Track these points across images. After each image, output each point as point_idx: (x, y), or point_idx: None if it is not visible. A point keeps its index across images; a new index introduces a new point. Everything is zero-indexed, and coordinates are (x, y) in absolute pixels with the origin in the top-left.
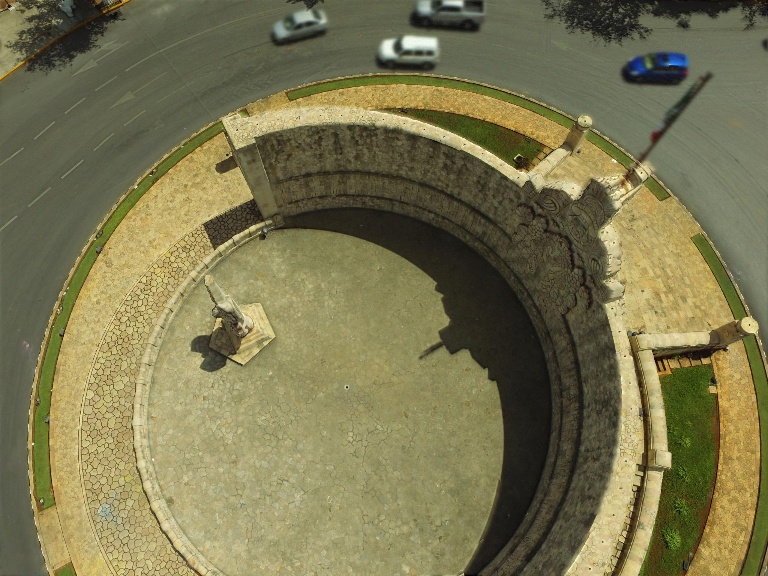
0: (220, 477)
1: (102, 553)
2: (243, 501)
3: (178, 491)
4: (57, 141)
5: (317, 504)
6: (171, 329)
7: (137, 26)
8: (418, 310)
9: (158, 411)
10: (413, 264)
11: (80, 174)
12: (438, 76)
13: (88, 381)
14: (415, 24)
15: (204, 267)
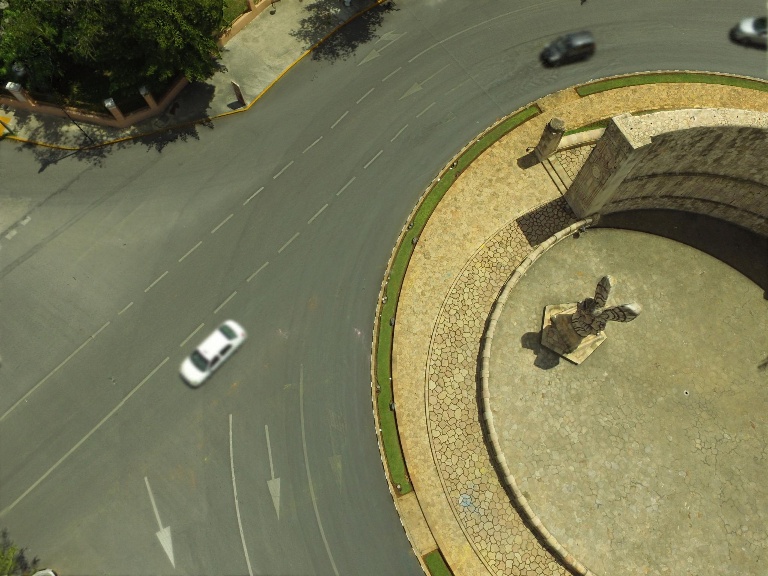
0: (572, 476)
1: (470, 543)
2: (599, 501)
3: (533, 487)
4: (354, 131)
5: (675, 510)
6: (499, 324)
7: (413, 17)
8: (749, 318)
9: (500, 405)
10: (736, 270)
11: (381, 165)
12: (731, 75)
13: (428, 372)
14: (697, 20)
15: (529, 264)
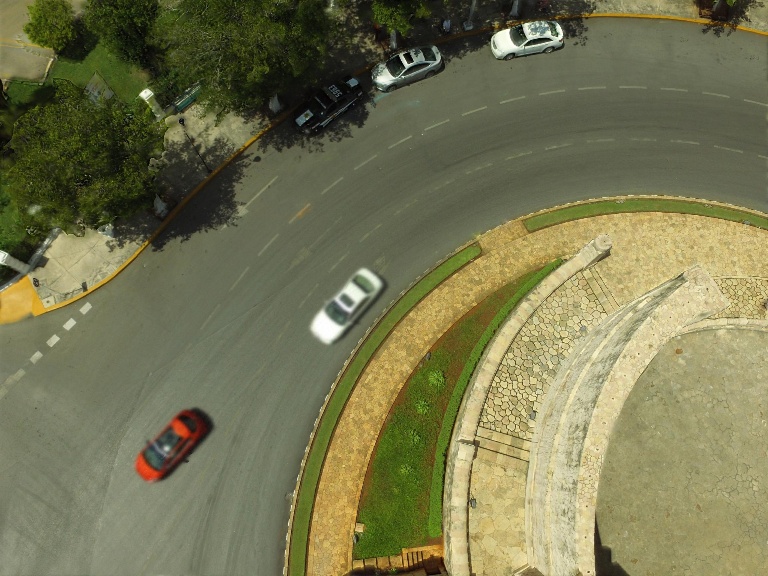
0: None
1: None
2: None
3: None
4: None
5: None
6: None
7: None
8: None
9: None
10: None
11: None
12: None
13: None
14: None
15: None
